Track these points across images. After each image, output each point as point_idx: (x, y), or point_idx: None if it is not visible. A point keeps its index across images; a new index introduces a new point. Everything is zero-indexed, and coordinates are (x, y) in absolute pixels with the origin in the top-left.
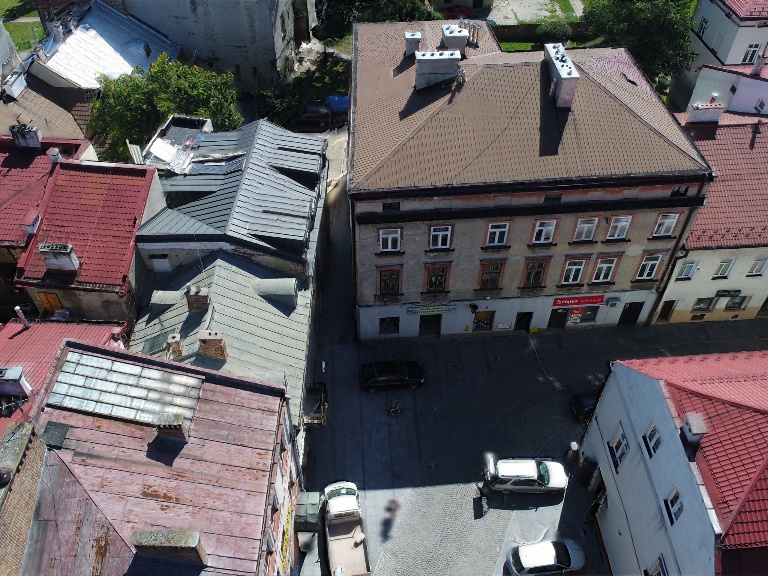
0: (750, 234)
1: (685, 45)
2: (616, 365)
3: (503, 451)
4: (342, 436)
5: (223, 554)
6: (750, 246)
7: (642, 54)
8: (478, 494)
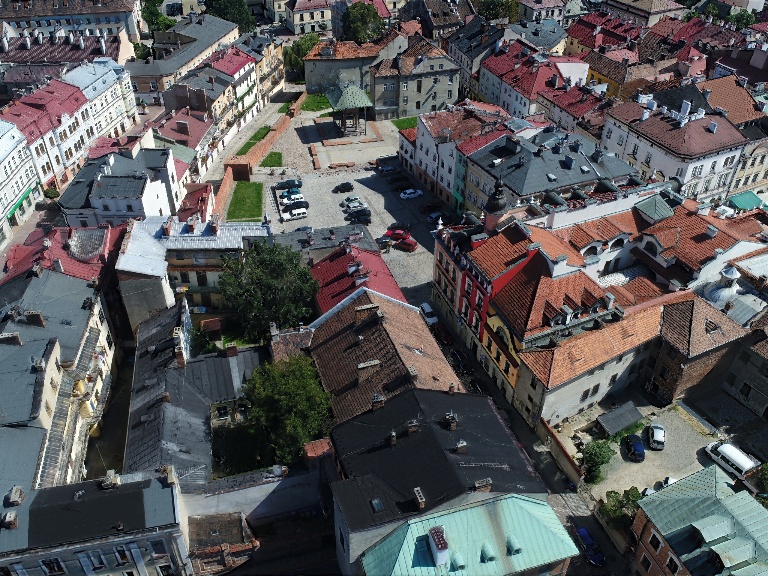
0: None
1: None
2: None
3: None
4: None
5: (544, 5)
6: None
7: None
8: None
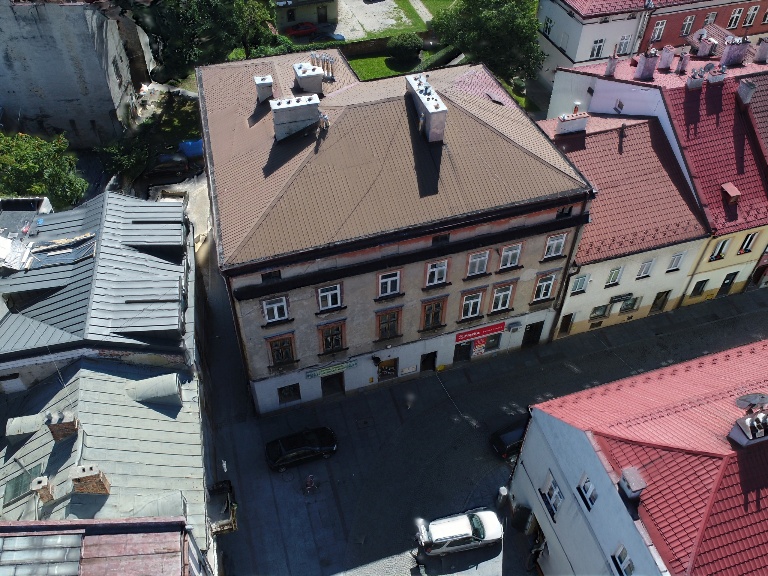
0: (634, 240)
1: (535, 47)
2: (535, 411)
3: (432, 509)
4: (258, 529)
5: None
6: (636, 252)
7: (496, 61)
8: (414, 563)
